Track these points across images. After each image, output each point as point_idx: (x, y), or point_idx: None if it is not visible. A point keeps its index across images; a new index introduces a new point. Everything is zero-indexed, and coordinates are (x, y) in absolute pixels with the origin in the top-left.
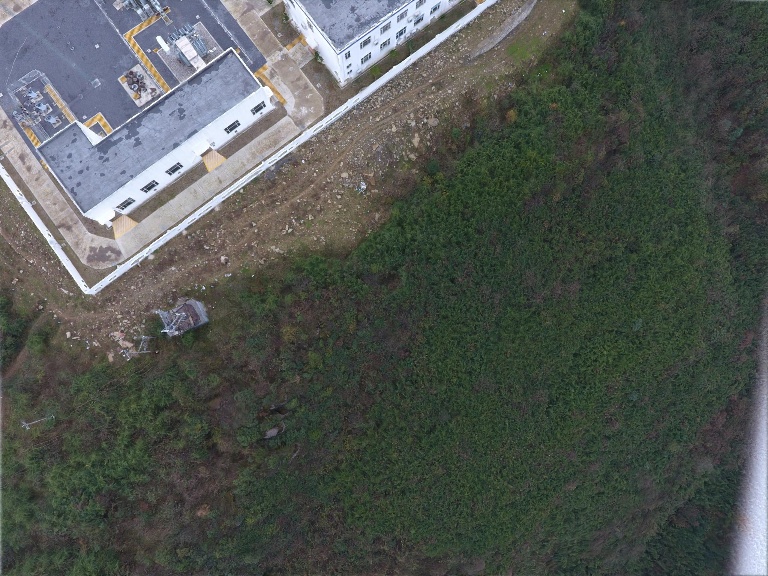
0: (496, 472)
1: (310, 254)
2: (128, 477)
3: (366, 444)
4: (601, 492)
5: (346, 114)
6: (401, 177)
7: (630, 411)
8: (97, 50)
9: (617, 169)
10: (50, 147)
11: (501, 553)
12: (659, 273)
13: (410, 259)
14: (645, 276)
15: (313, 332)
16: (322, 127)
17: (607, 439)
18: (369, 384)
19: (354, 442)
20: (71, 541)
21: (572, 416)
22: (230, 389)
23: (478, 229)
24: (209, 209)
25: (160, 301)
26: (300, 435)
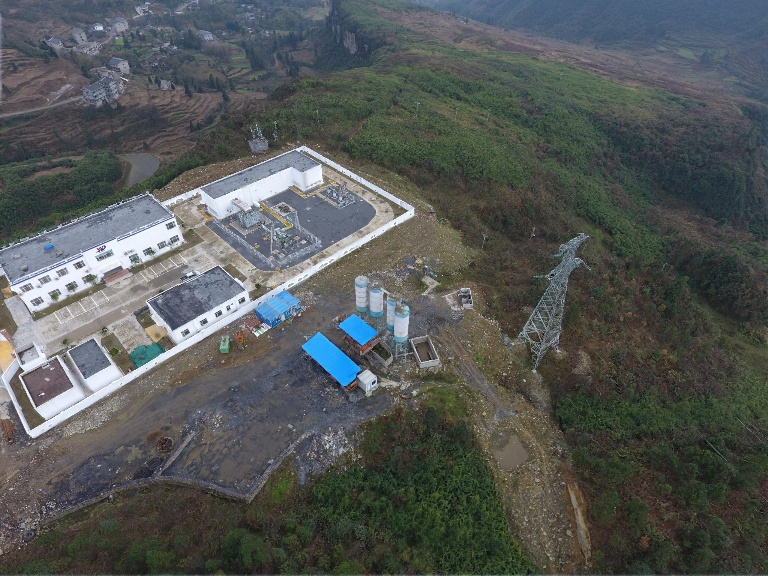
0: None
1: None
2: None
3: None
4: None
5: None
6: None
7: None
8: None
9: None
10: None
11: None
12: None
13: None
14: None
15: None
16: (178, 203)
17: None
18: None
19: None
20: None
21: None
22: None
23: None
24: None
25: None
26: None
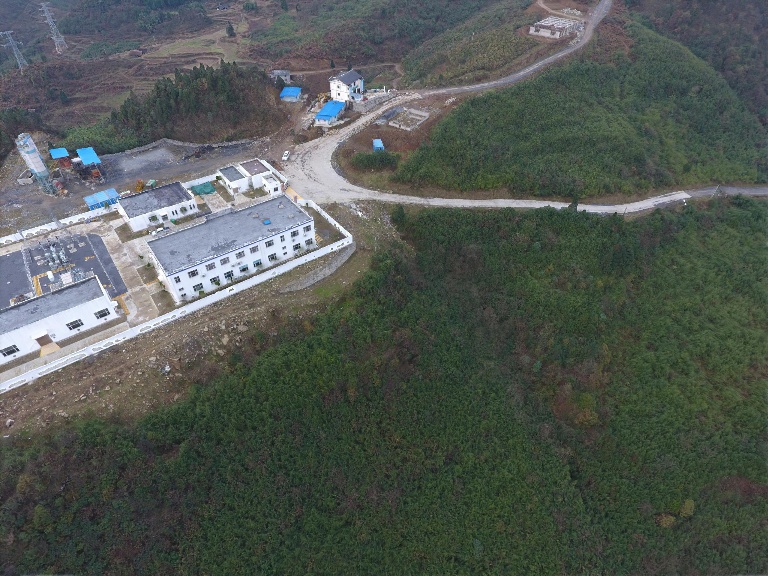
0: None
1: None
2: None
3: None
4: None
5: (173, 321)
6: (208, 367)
7: None
8: (7, 285)
9: (416, 378)
10: None
11: None
12: (488, 486)
13: (197, 435)
14: (473, 488)
15: (54, 486)
16: (150, 329)
17: None
18: None
19: None
20: None
21: None
22: None
23: (274, 415)
24: (23, 383)
25: None
26: None
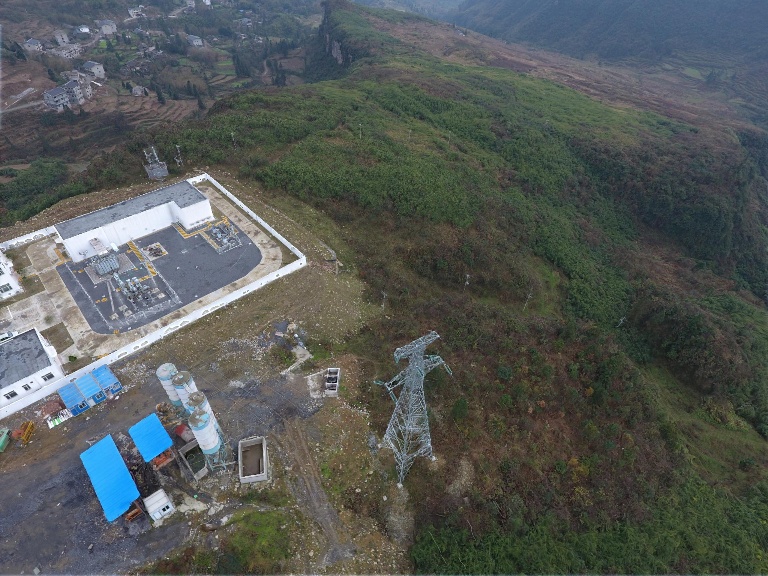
0: None
1: None
2: None
3: None
4: None
5: None
6: None
7: None
8: None
9: None
10: None
11: None
12: None
13: None
14: None
15: None
16: None
17: None
18: None
19: None
20: None
21: None
22: None
23: None
24: None
25: None
26: None
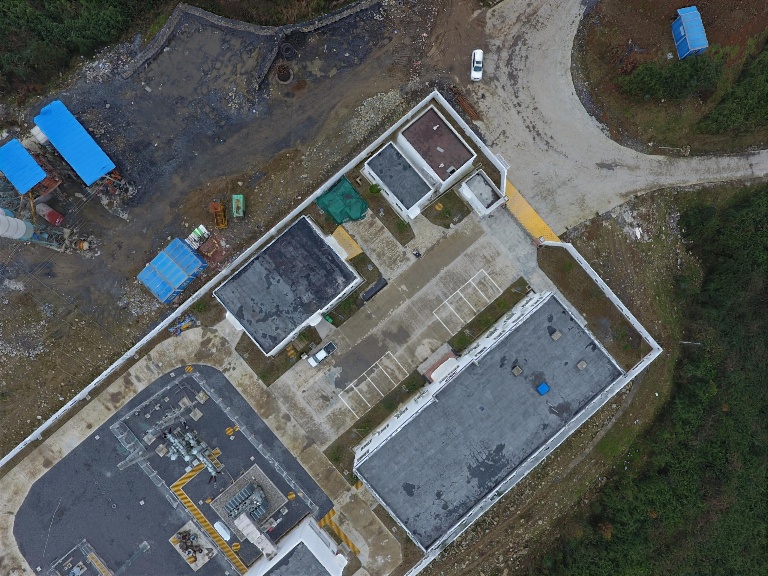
0: None
1: None
2: None
3: None
4: None
5: None
6: None
7: None
8: (142, 506)
9: None
10: None
11: None
12: None
13: None
14: None
15: None
16: None
17: None
18: None
19: None
20: None
21: None
22: None
23: None
24: None
25: None
26: None
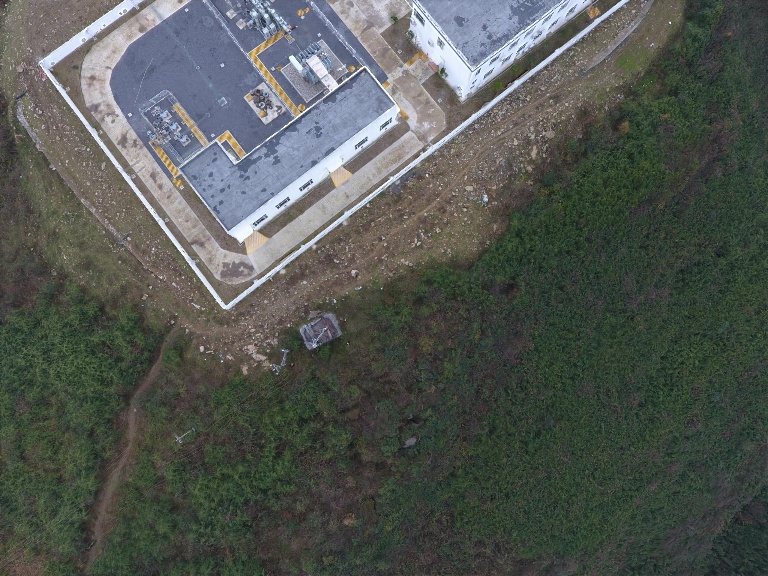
0: (588, 474)
1: (436, 266)
2: (275, 488)
3: (481, 450)
4: (677, 491)
5: (467, 128)
6: (517, 189)
7: (709, 412)
8: (222, 69)
9: (714, 176)
10: (191, 166)
11: (588, 553)
12: (745, 276)
13: (526, 269)
14: (732, 279)
15: (447, 343)
16: (444, 141)
17: (686, 439)
18: (486, 392)
19: (470, 448)
20: (217, 551)
21: (660, 418)
22: (369, 400)
23: (588, 238)
24: (337, 224)
25: (292, 315)
26: (431, 443)
